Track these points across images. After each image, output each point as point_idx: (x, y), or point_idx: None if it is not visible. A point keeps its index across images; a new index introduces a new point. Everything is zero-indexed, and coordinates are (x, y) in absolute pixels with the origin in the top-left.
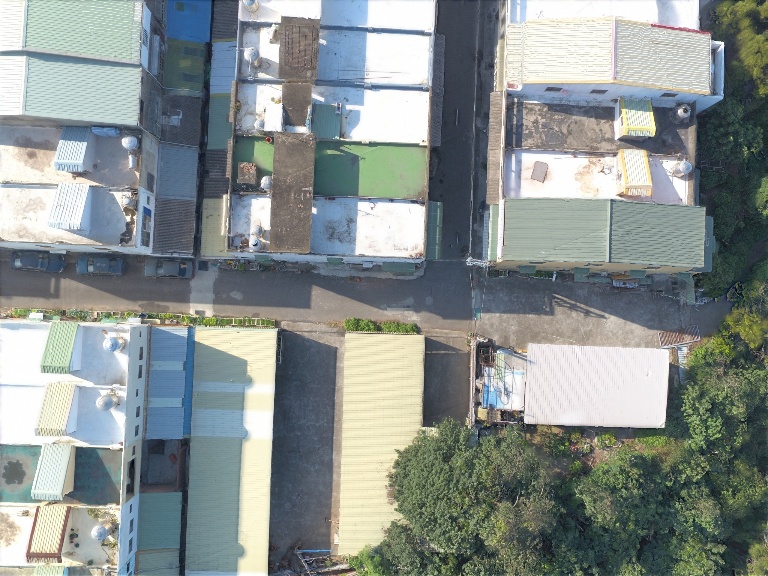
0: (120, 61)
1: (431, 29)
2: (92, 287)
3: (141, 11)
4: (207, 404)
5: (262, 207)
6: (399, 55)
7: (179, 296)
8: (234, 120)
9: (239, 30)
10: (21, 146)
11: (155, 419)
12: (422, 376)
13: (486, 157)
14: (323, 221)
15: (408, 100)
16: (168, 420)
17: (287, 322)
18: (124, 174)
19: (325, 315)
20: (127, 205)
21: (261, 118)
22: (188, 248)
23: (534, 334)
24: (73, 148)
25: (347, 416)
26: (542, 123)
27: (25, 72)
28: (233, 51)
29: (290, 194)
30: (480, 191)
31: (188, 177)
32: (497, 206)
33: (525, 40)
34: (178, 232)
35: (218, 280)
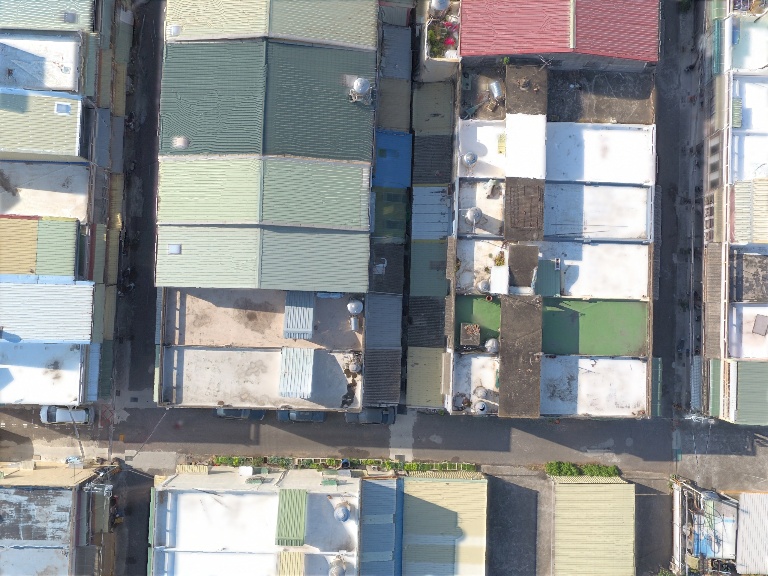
0: (350, 229)
1: (650, 182)
2: (292, 433)
3: (369, 176)
4: (417, 557)
5: (482, 366)
6: (617, 208)
7: (378, 441)
8: (455, 279)
9: (458, 187)
10: (241, 308)
11: (367, 574)
12: (633, 526)
13: (683, 294)
14: (544, 379)
15: (627, 254)
16: (380, 574)
17: (487, 466)
18: (344, 335)
19: (525, 458)
20: (354, 371)
21: (479, 275)
22: (395, 398)
23: (736, 475)
24: (300, 315)
25: (559, 568)
26: (763, 275)
27: (260, 245)
28: (436, 197)
29: (518, 358)
30: (678, 329)
31: (393, 326)
32: (718, 361)
33: (755, 198)
34: (385, 383)
35: (417, 424)
